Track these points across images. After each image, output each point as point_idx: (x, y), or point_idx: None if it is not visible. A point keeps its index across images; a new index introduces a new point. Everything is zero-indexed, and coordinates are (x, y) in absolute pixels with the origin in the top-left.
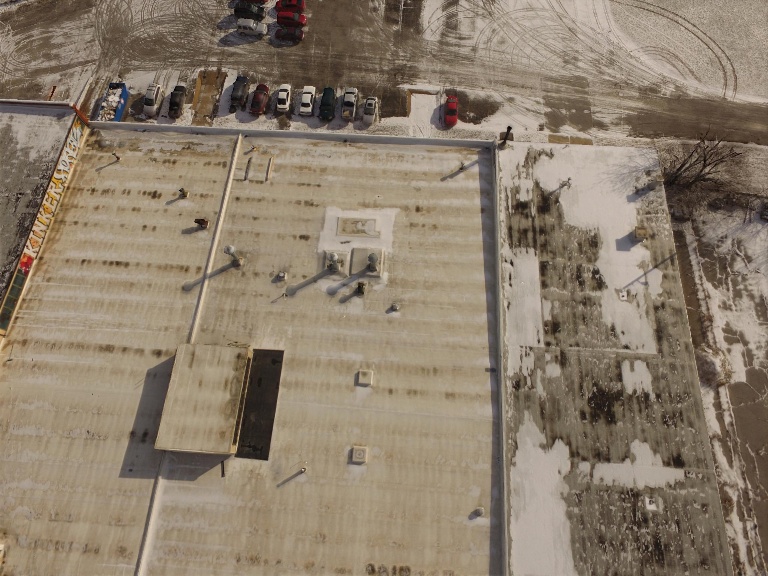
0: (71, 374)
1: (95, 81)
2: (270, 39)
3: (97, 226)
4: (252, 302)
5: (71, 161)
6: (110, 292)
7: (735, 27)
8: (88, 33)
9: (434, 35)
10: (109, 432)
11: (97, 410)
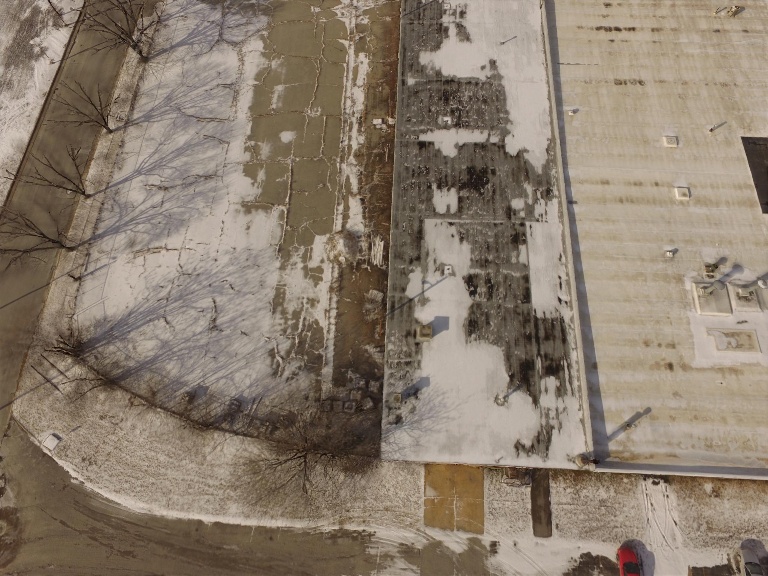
0: None
1: None
2: None
3: None
4: None
5: None
6: None
7: None
8: None
9: None
10: None
11: None
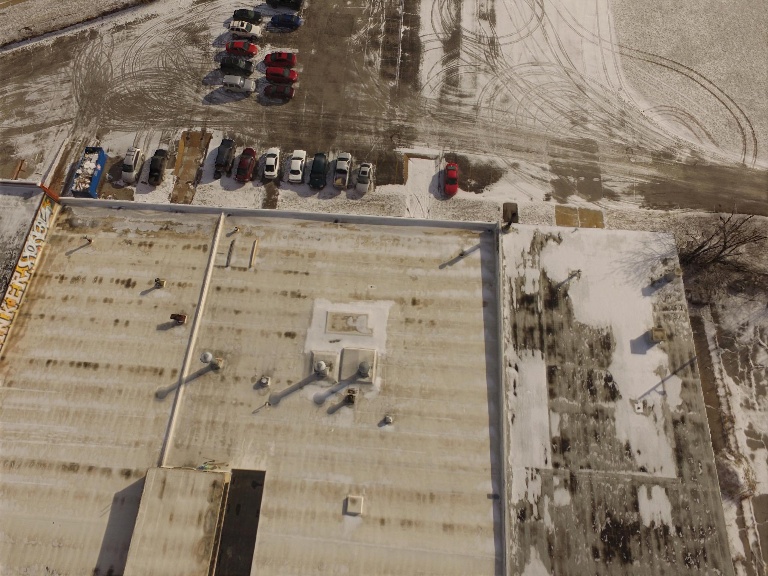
0: (31, 498)
1: (71, 142)
2: (258, 96)
3: (65, 320)
4: (232, 412)
5: (39, 244)
6: (77, 399)
7: (754, 84)
8: (65, 89)
9: (433, 92)
10: (70, 569)
11: (58, 542)
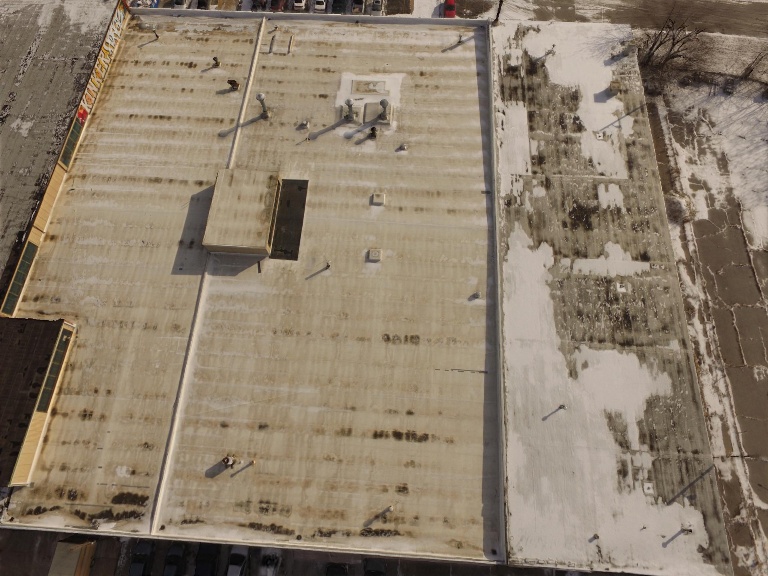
0: (126, 199)
1: None
2: None
3: (141, 89)
4: (279, 145)
5: (116, 38)
6: (156, 139)
7: None
8: None
9: None
10: (161, 241)
11: (150, 225)
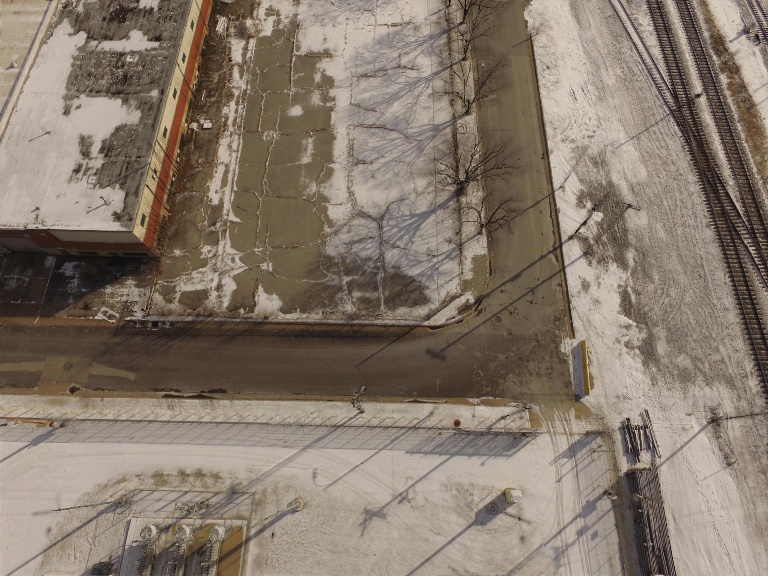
0: None
1: None
2: None
3: None
4: None
5: None
6: None
7: None
8: None
9: None
10: None
11: None
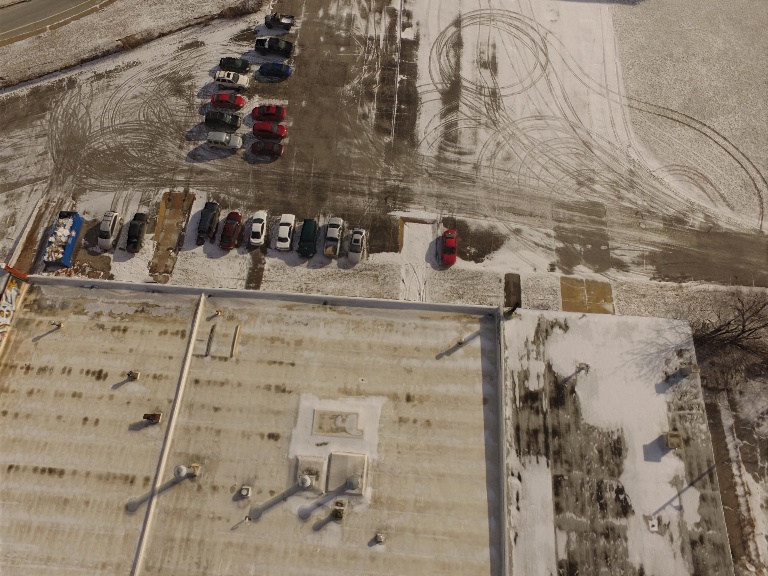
0: None
1: (45, 204)
2: (245, 153)
3: (29, 418)
4: (208, 528)
5: (3, 330)
6: (39, 512)
7: None
8: (40, 144)
9: (431, 149)
10: None
11: None
